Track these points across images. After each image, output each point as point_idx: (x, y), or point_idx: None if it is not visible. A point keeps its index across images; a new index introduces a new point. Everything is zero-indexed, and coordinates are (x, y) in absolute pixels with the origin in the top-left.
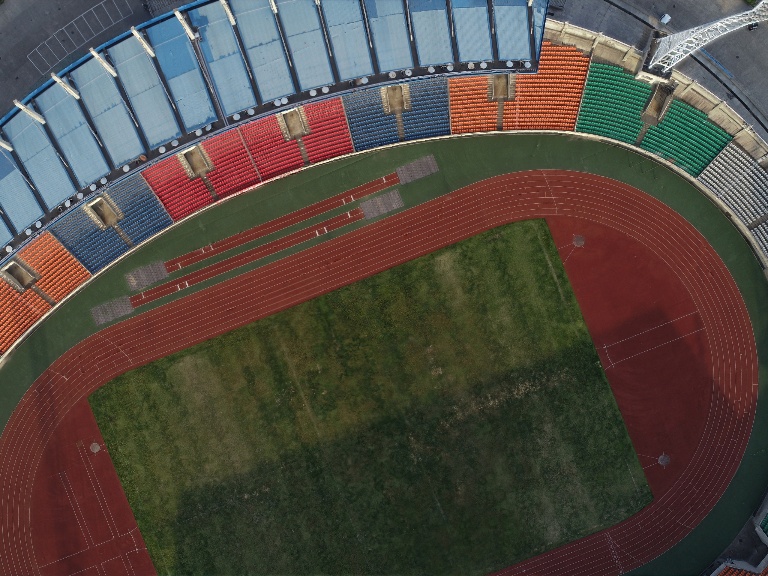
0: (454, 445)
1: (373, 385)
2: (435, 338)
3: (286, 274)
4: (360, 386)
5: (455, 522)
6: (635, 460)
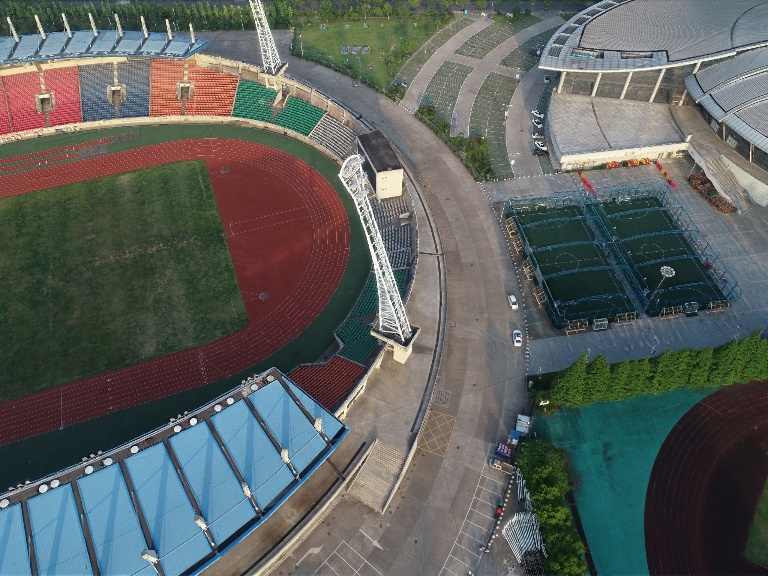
0: (84, 282)
1: (35, 243)
2: (99, 217)
3: (5, 183)
4: (24, 244)
5: (60, 338)
6: (238, 295)
